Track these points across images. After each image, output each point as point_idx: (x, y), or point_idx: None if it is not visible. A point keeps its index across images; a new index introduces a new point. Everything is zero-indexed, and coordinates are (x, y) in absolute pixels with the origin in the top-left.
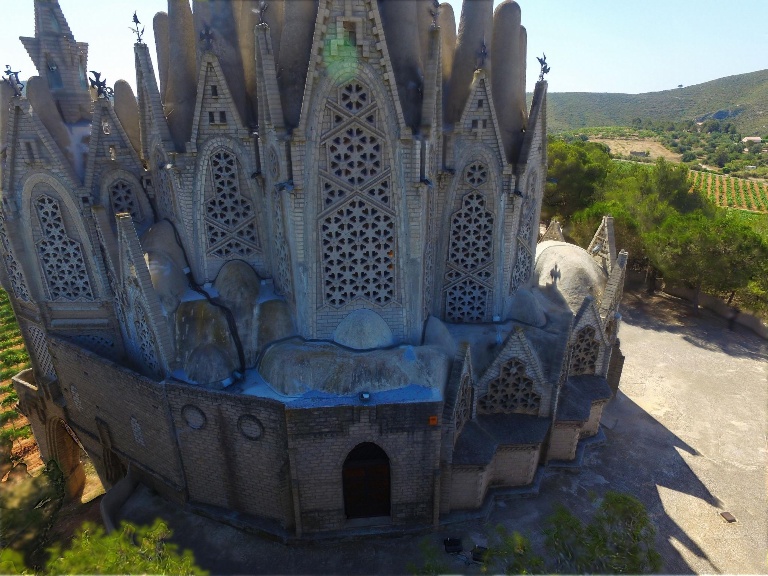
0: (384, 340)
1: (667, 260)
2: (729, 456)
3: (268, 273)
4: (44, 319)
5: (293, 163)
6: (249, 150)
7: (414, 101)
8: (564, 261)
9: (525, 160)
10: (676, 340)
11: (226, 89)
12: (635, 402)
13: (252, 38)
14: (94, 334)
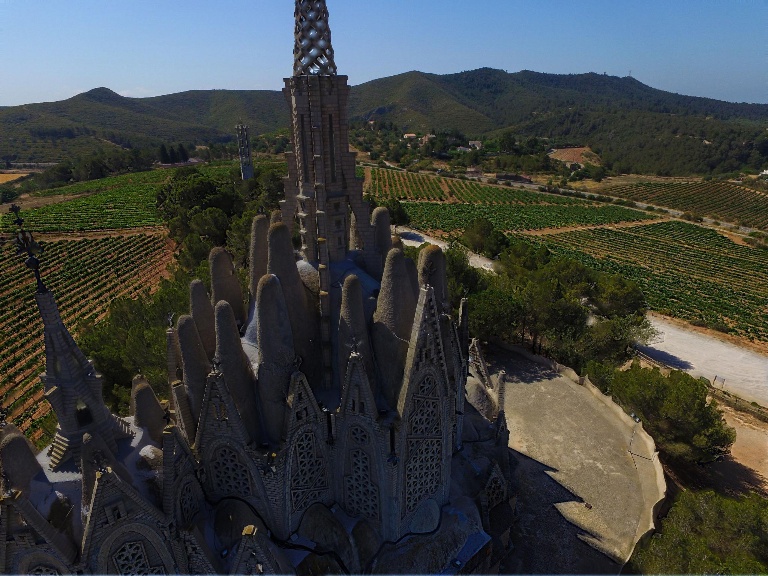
0: None
1: (474, 326)
2: (567, 464)
3: (332, 500)
4: None
5: (396, 442)
6: (322, 424)
7: None
8: None
9: (467, 351)
10: None
11: (311, 393)
12: (509, 447)
13: None
14: None
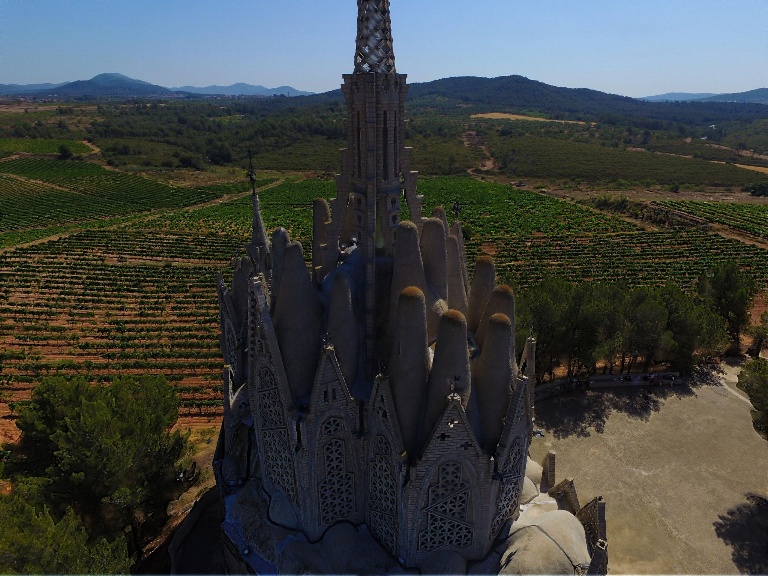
0: (287, 522)
1: None
2: None
3: None
4: None
5: None
6: None
7: None
8: (520, 554)
9: (421, 456)
10: None
11: None
12: None
13: None
14: None
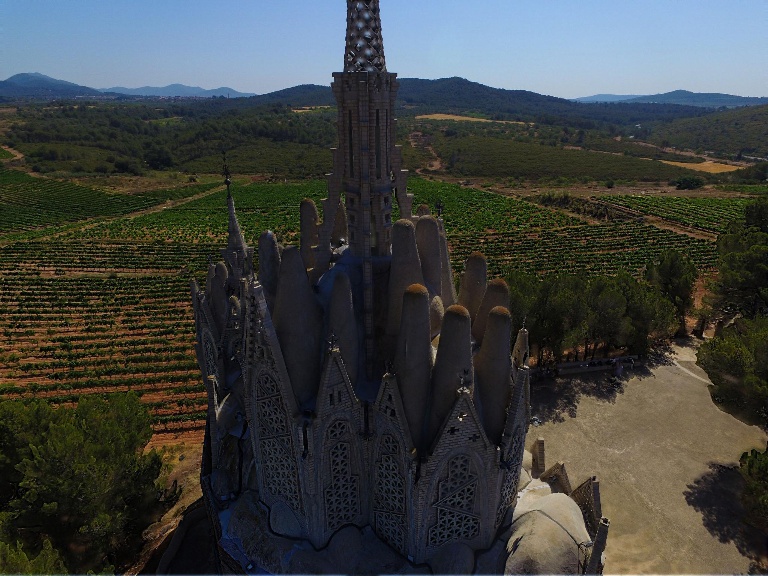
0: (291, 532)
1: None
2: None
3: None
4: None
5: None
6: None
7: None
8: (527, 539)
9: (432, 452)
10: None
11: None
12: None
13: None
14: None
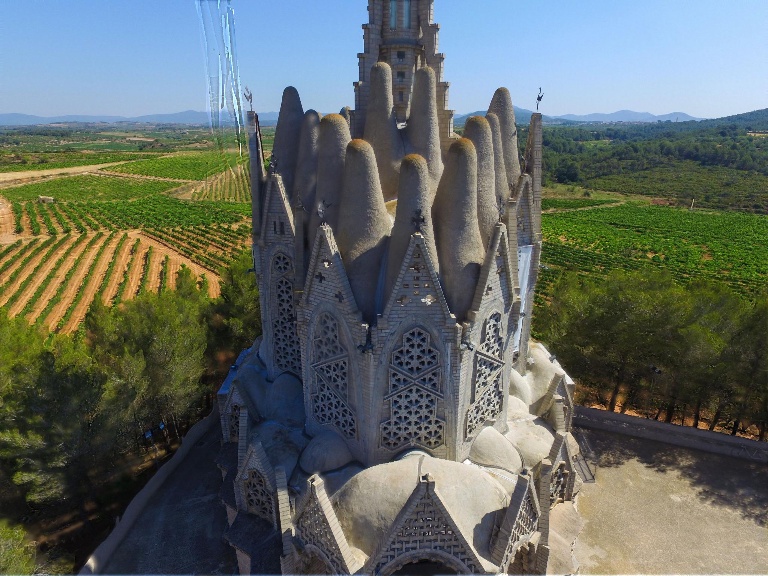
0: None
1: None
2: None
3: None
4: None
5: None
6: None
7: None
8: None
9: None
10: None
11: None
12: None
13: None
14: None
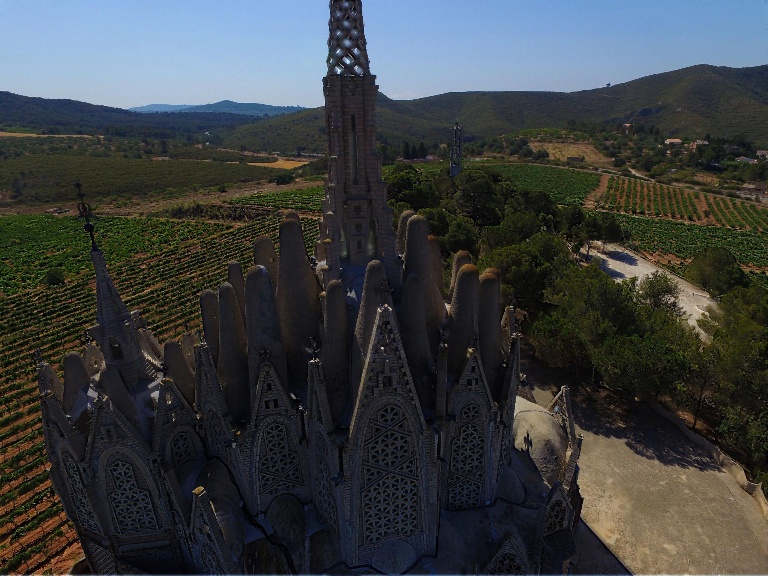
0: (411, 561)
1: (609, 374)
2: None
3: (309, 498)
4: (113, 548)
5: (344, 463)
6: (295, 420)
7: (428, 390)
8: (534, 431)
9: (506, 396)
10: (620, 447)
11: (279, 386)
12: (593, 530)
13: (288, 317)
14: (156, 552)
